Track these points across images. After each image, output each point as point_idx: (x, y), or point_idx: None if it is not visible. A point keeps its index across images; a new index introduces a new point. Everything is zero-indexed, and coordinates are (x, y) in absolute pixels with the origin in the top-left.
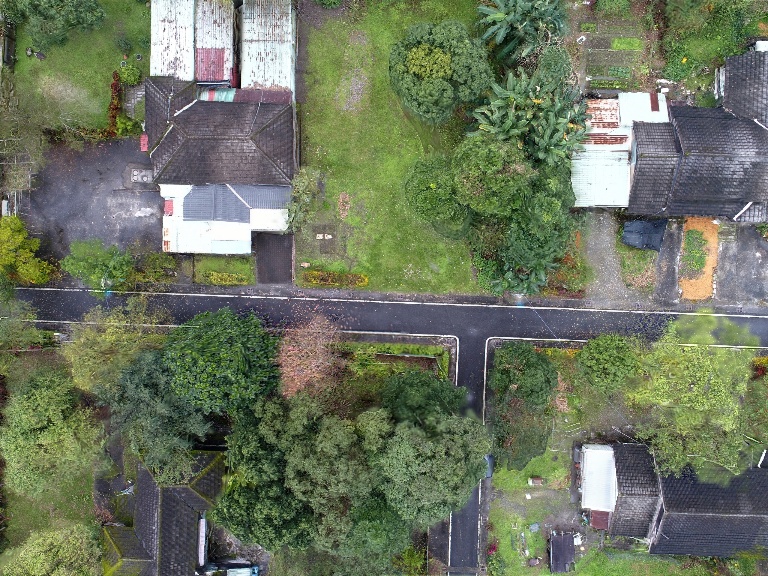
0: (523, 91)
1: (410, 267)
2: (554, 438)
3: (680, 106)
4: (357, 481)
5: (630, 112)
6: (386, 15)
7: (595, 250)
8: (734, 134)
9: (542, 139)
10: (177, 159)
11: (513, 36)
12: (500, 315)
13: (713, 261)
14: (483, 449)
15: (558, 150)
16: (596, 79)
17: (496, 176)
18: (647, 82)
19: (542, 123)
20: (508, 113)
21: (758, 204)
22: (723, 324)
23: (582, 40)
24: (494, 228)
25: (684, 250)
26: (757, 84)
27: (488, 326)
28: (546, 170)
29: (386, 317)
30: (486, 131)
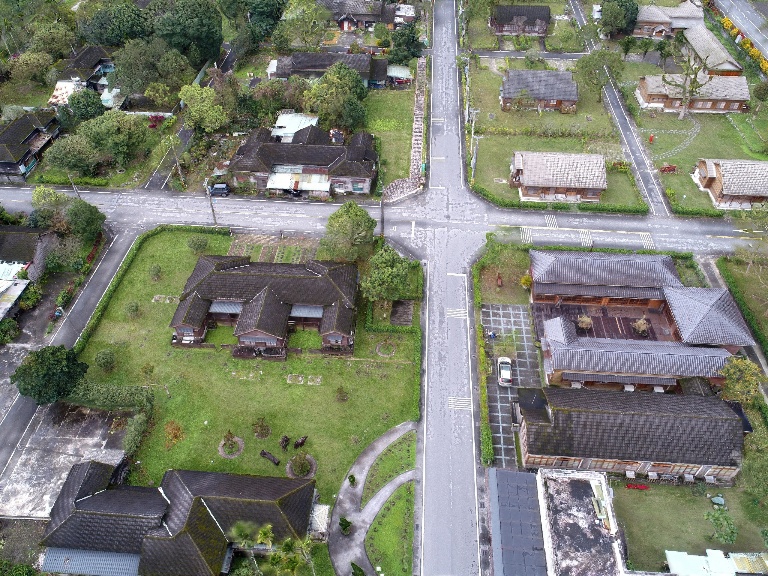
0: None
1: None
2: (260, 60)
3: None
4: (166, 5)
5: None
6: None
7: None
8: None
9: None
10: (140, 2)
11: None
12: None
13: None
14: (214, 5)
15: None
16: None
17: None
18: None
19: None
20: None
21: None
22: None
23: None
24: (243, 4)
25: None
26: None
27: None
28: None
29: None
30: None
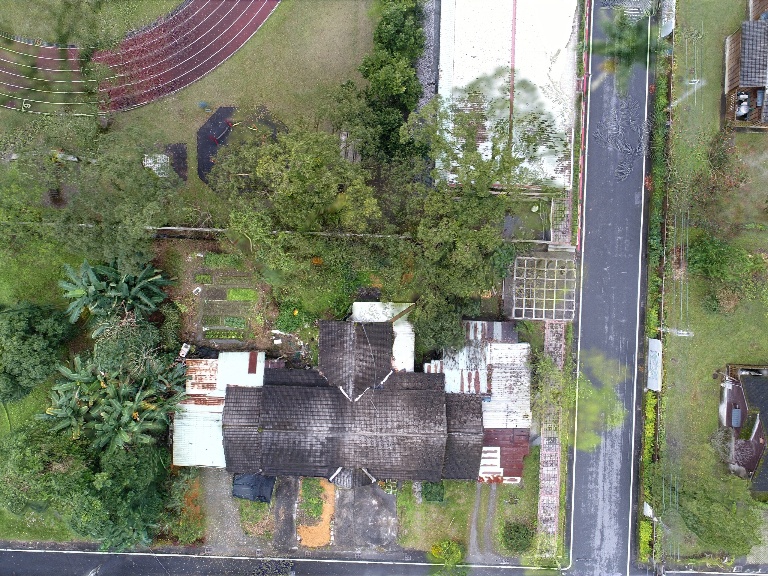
0: (91, 374)
1: (32, 515)
2: None
3: (277, 368)
4: None
5: (225, 375)
6: (5, 267)
7: (214, 498)
8: (314, 405)
9: (107, 423)
10: None
11: (86, 316)
12: (121, 562)
13: (330, 508)
14: None
15: (125, 433)
16: (212, 330)
17: (36, 477)
18: (263, 332)
19: (106, 408)
20: (72, 399)
21: (346, 470)
22: (342, 570)
23: (198, 291)
24: (62, 510)
25: (302, 497)
26: (342, 352)
27: (109, 573)
28: (102, 460)
29: (8, 565)
30: (52, 416)
